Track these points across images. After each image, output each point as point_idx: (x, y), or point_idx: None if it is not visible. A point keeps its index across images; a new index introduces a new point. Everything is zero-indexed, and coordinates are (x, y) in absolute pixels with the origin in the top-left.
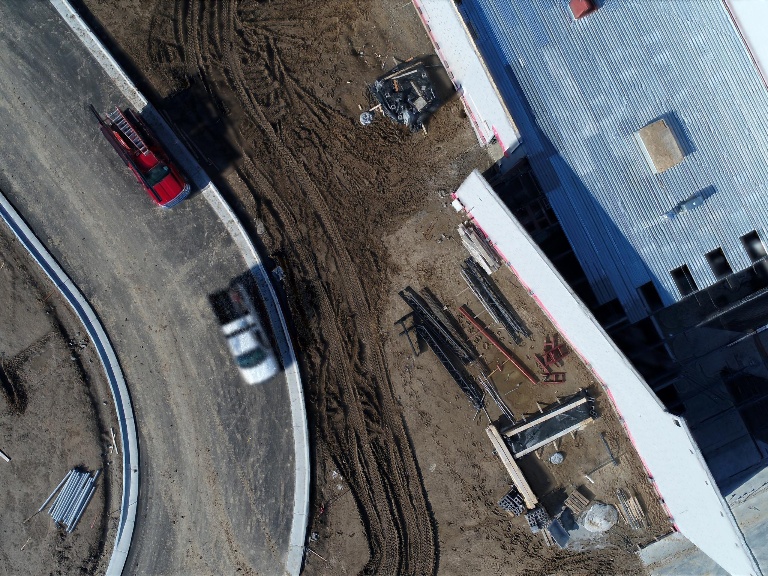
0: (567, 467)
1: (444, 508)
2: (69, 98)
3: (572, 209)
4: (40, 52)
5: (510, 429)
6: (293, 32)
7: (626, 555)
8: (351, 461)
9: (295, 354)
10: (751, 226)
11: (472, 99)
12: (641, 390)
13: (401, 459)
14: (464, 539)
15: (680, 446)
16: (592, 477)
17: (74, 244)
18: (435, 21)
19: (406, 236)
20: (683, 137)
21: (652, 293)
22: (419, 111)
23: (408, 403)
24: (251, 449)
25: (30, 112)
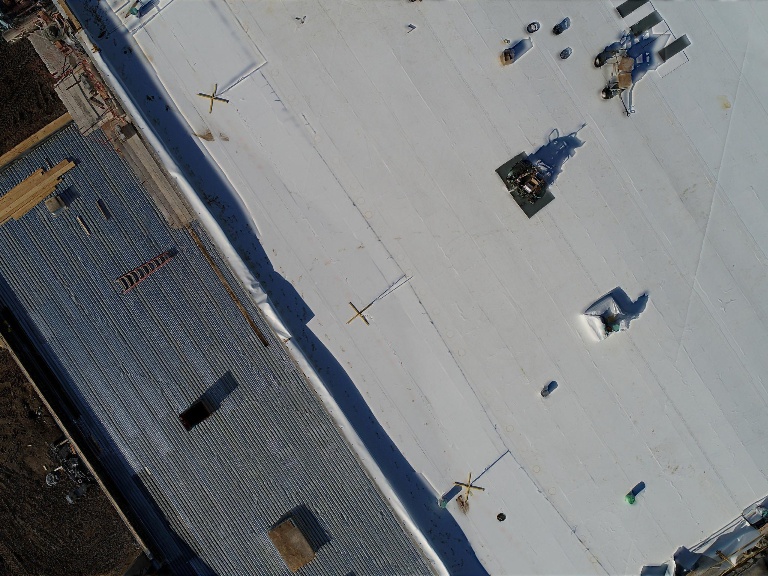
0: None
1: None
2: None
3: None
4: None
5: None
6: None
7: None
8: None
9: None
10: None
11: None
12: None
13: None
14: None
15: None
16: None
17: None
18: None
19: None
20: (318, 527)
21: None
22: None
23: None
24: None
25: None
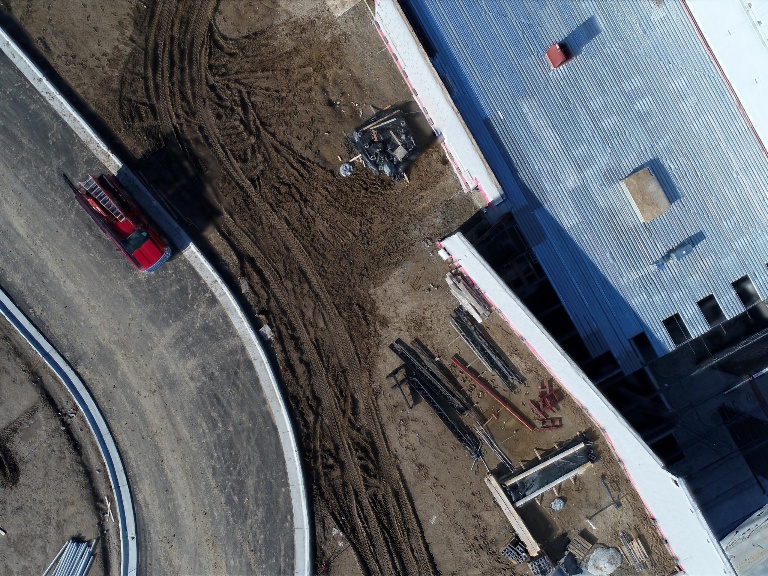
0: (568, 512)
1: (446, 559)
2: (42, 164)
3: (560, 262)
4: (9, 118)
5: (509, 477)
6: (267, 85)
7: None
8: (350, 517)
9: (287, 413)
10: (743, 271)
11: (453, 148)
12: (638, 446)
13: (400, 512)
14: None
15: (680, 502)
16: (594, 521)
17: (56, 313)
18: (411, 70)
19: (393, 287)
20: (670, 183)
21: (645, 343)
22: (400, 160)
23: (404, 456)
24: (248, 510)
25: (3, 180)
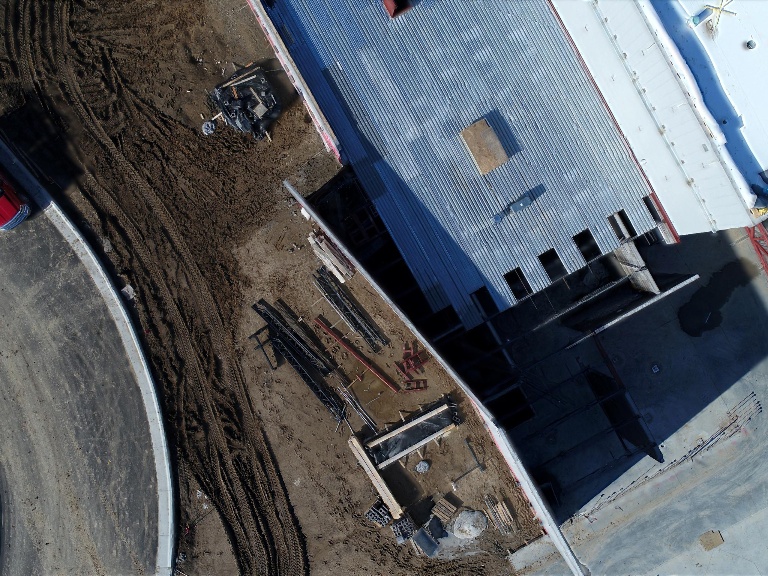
0: (433, 475)
1: (311, 522)
2: None
3: (400, 216)
4: None
5: (373, 439)
6: (128, 42)
7: (497, 560)
8: (214, 479)
9: (150, 374)
10: (584, 224)
11: (308, 104)
12: None
13: (265, 475)
14: (333, 552)
15: (510, 456)
16: (459, 484)
17: None
18: (264, 24)
19: (257, 247)
20: (510, 136)
21: (487, 298)
22: (260, 118)
23: (268, 418)
24: (112, 472)
25: None
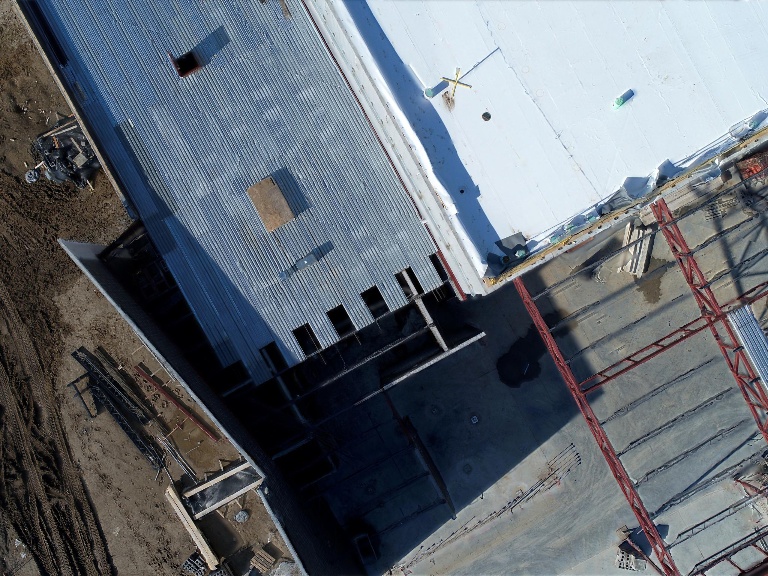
0: (253, 525)
1: (130, 572)
2: None
3: (190, 271)
4: None
5: (191, 489)
6: None
7: None
8: (33, 528)
9: None
10: (371, 281)
11: None
12: None
13: (84, 524)
14: None
15: None
16: (279, 534)
17: None
18: None
19: (78, 295)
20: (298, 193)
21: (277, 353)
22: (80, 168)
23: (88, 466)
24: None
25: None
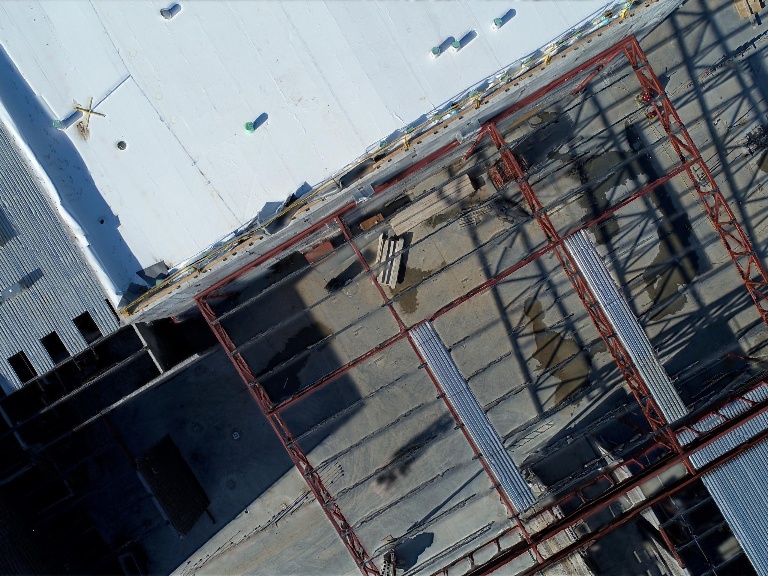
0: None
1: None
2: None
3: None
4: None
5: None
6: None
7: None
8: None
9: None
10: (83, 307)
11: None
12: None
13: None
14: None
15: None
16: None
17: None
18: None
19: None
20: (5, 221)
21: None
22: None
23: None
24: None
25: None
